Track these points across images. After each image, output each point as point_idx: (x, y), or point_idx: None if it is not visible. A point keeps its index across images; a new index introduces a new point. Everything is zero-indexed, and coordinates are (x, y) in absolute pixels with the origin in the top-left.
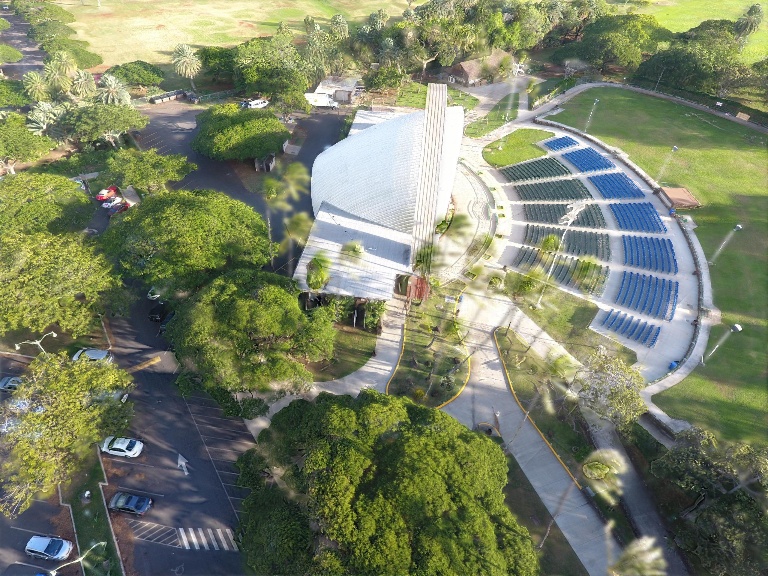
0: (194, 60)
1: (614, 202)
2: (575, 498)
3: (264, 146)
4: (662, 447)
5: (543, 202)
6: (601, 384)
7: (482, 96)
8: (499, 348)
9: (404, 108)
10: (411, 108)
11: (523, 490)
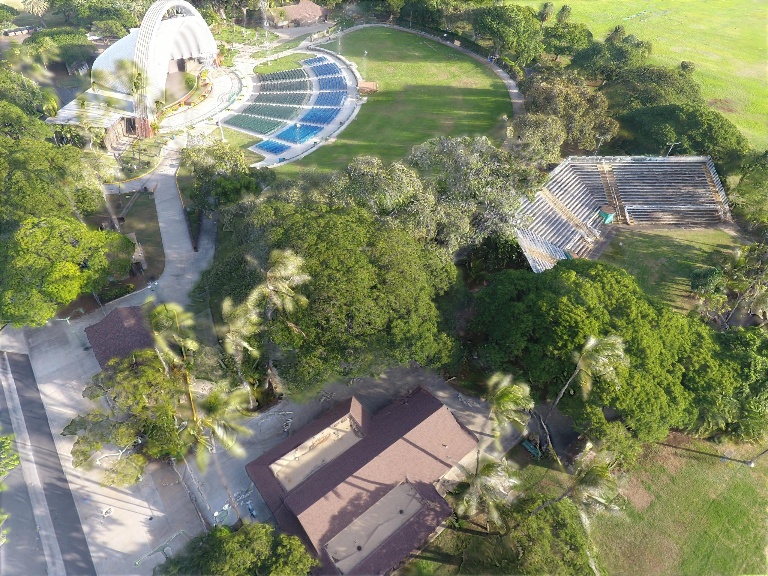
0: (41, 1)
1: None
2: (178, 212)
3: (69, 53)
4: None
5: None
6: (187, 144)
7: (285, 34)
8: (182, 158)
9: None
10: (221, 41)
11: (149, 210)
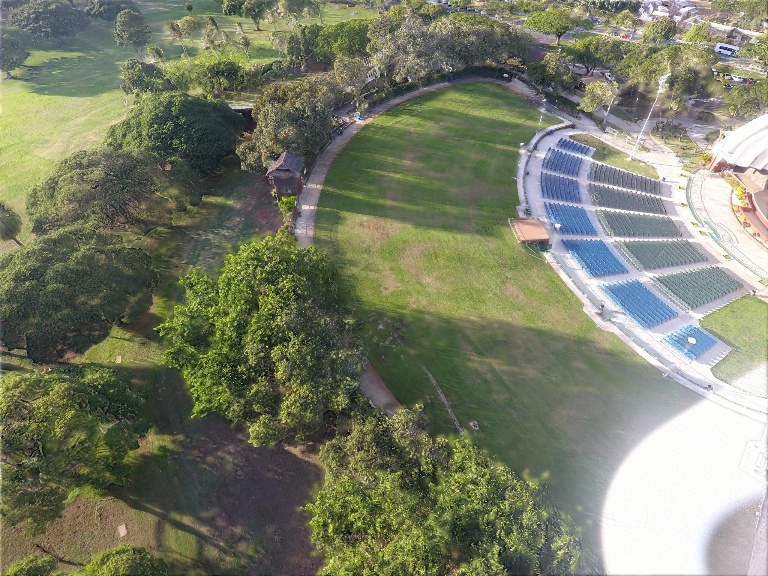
0: None
1: None
2: None
3: None
4: (567, 102)
5: None
6: None
7: None
8: None
9: None
10: None
11: None
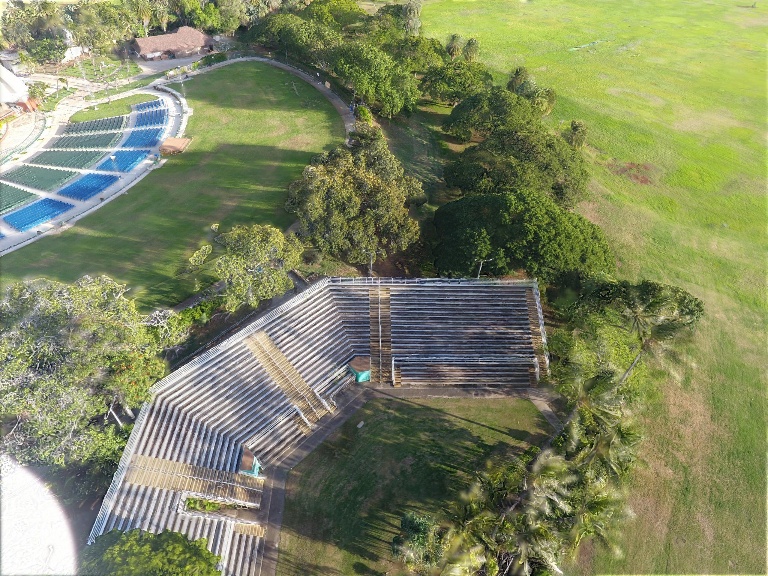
0: None
1: (127, 150)
2: None
3: None
4: None
5: (68, 149)
6: None
7: (150, 68)
8: None
9: (61, 77)
10: (67, 77)
11: None
